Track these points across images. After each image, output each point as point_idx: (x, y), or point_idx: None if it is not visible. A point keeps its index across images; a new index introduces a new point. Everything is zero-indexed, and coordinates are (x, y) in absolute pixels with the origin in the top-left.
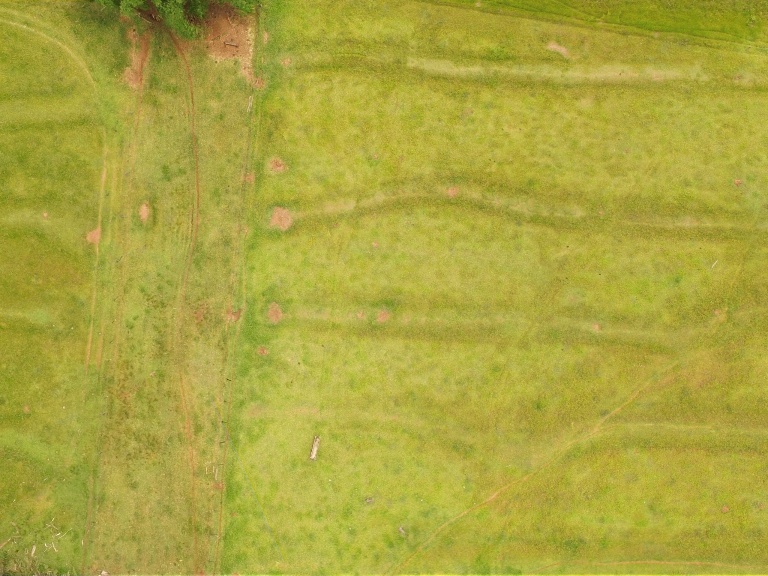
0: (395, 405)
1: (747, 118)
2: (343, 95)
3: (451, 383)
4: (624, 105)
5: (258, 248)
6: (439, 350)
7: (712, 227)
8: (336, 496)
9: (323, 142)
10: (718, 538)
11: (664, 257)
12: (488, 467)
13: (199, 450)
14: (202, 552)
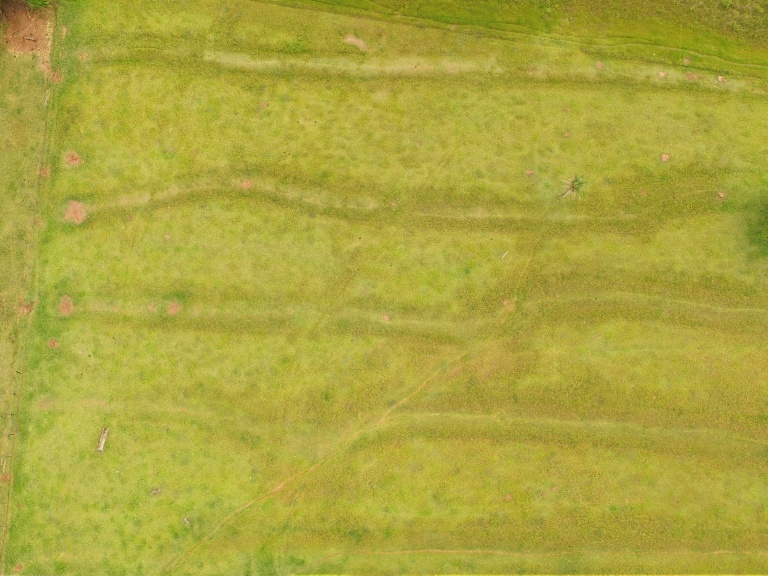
0: (184, 397)
1: (540, 110)
2: (140, 89)
3: (241, 374)
4: (419, 97)
5: (52, 241)
6: (229, 342)
7: (503, 218)
8: (123, 487)
9: (119, 136)
10: (501, 526)
11: (455, 248)
12: (275, 458)
13: None
14: None
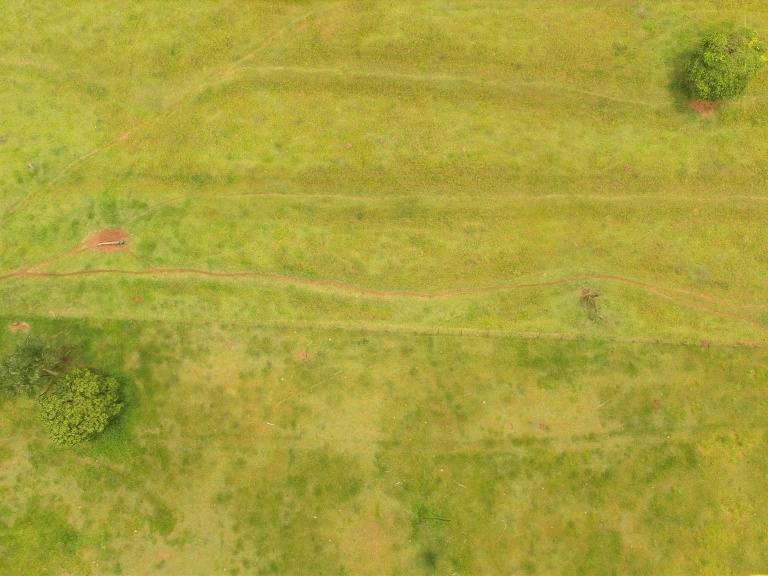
0: (32, 51)
1: None
2: None
3: (88, 31)
4: None
5: None
6: None
7: None
8: None
9: None
10: (340, 173)
11: None
12: (120, 109)
13: None
14: None
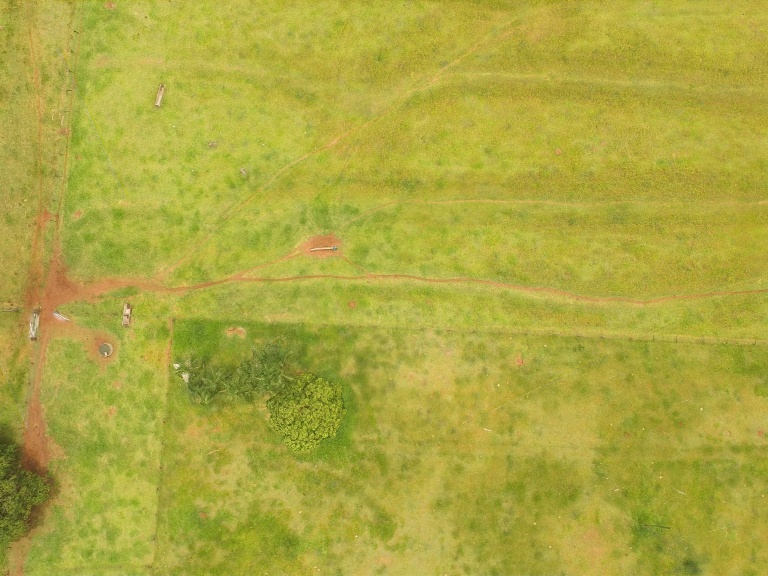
0: (239, 57)
1: None
2: None
3: (295, 37)
4: None
5: None
6: (284, 5)
7: None
8: (180, 141)
9: None
10: (551, 178)
11: None
12: (329, 114)
13: (46, 98)
14: (47, 192)
